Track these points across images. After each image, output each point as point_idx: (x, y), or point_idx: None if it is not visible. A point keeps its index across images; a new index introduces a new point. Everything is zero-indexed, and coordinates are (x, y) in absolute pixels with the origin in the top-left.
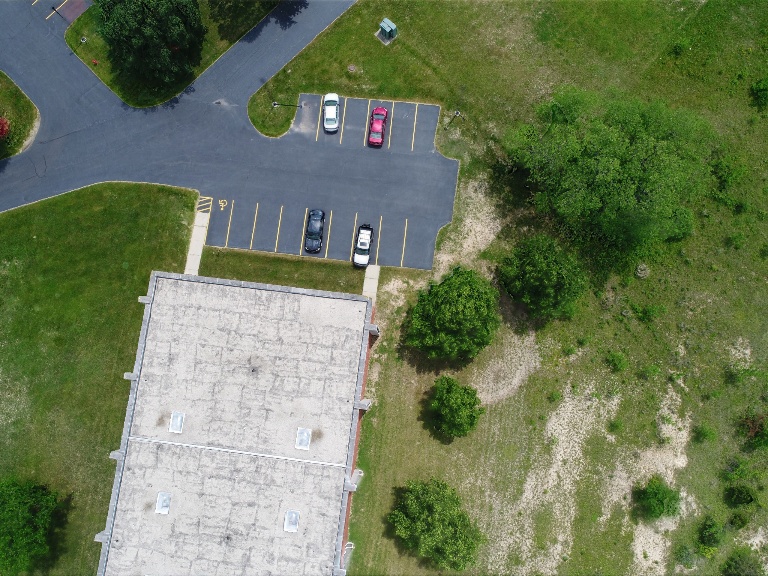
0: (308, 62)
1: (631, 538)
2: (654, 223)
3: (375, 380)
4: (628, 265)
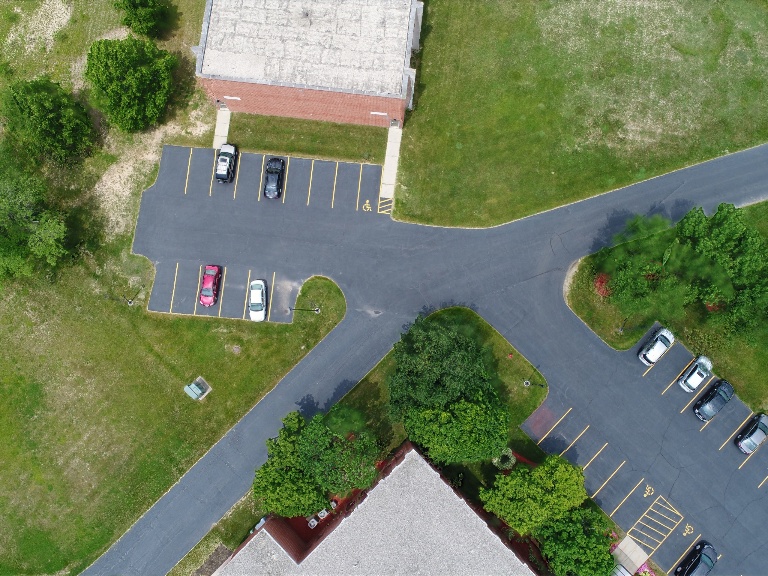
0: (283, 357)
1: None
2: None
3: None
4: None
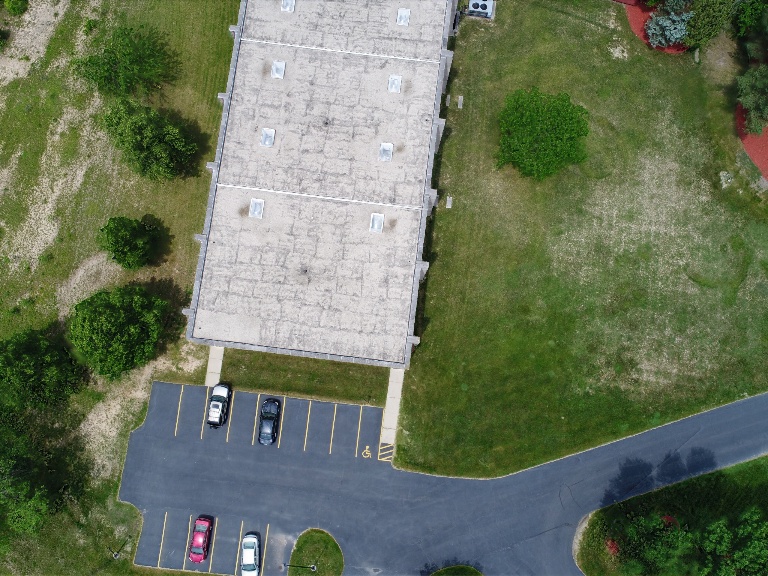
0: None
1: None
2: None
3: None
4: None
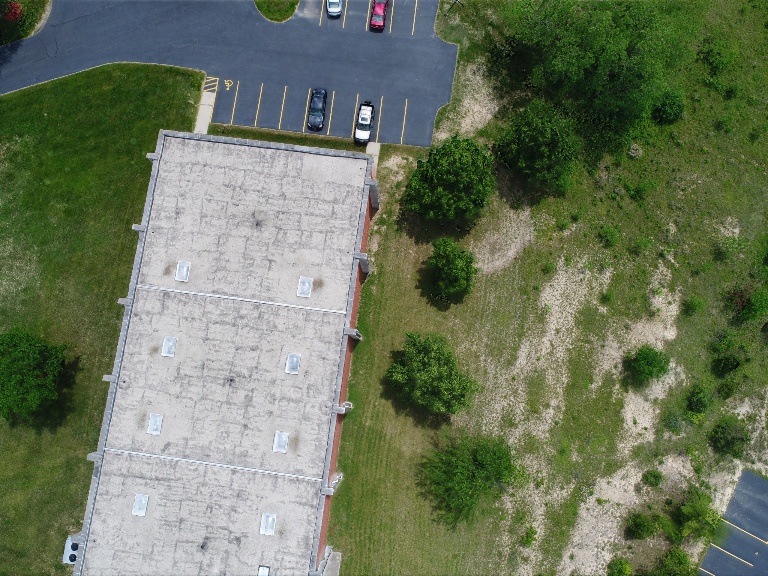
0: None
1: (621, 405)
2: (646, 99)
3: (375, 250)
4: (621, 146)
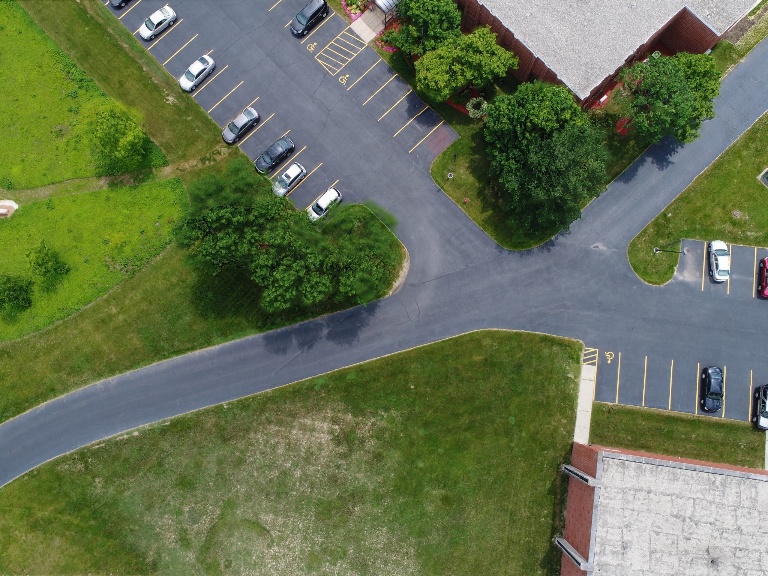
0: (689, 206)
1: None
2: None
3: None
4: None
